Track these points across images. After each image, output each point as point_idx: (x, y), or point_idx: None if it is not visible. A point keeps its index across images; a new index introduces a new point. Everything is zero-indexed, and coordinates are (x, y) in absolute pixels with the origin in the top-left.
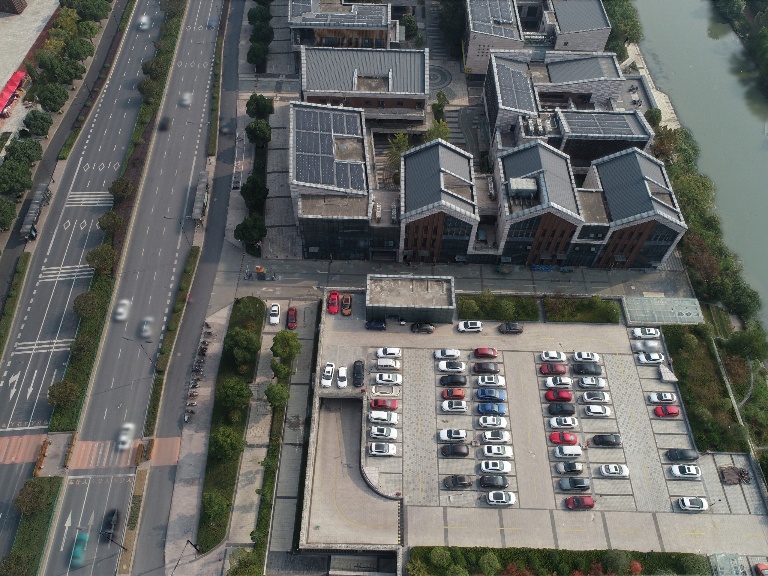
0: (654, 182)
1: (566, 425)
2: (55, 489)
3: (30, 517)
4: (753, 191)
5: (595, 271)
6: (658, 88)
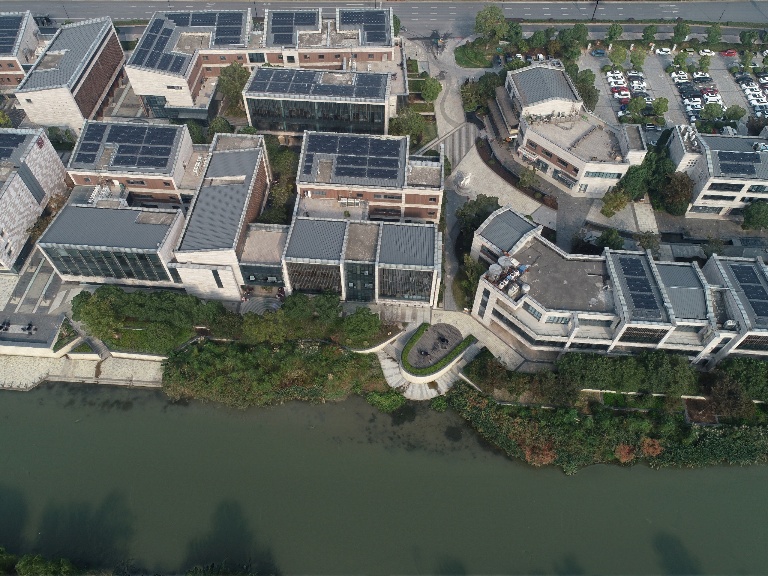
0: None
1: None
2: None
3: None
4: None
5: None
6: None
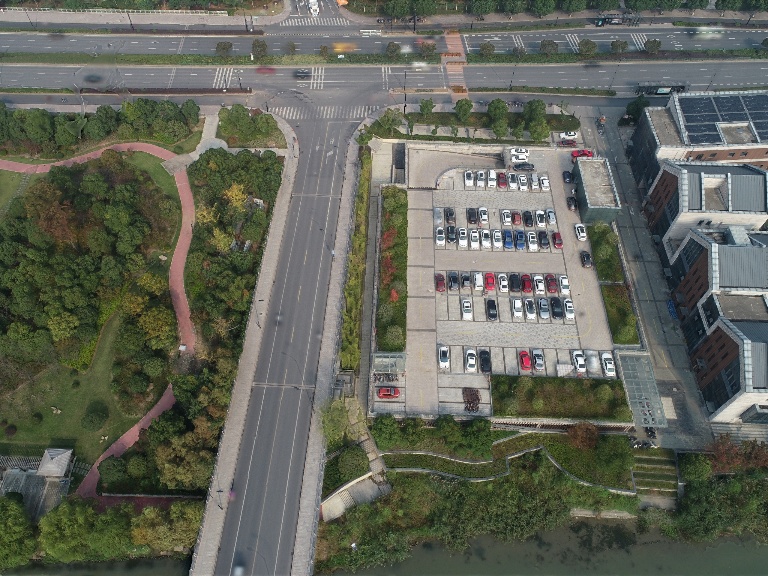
0: None
1: None
2: (434, 61)
3: (419, 56)
4: None
5: (685, 357)
6: None
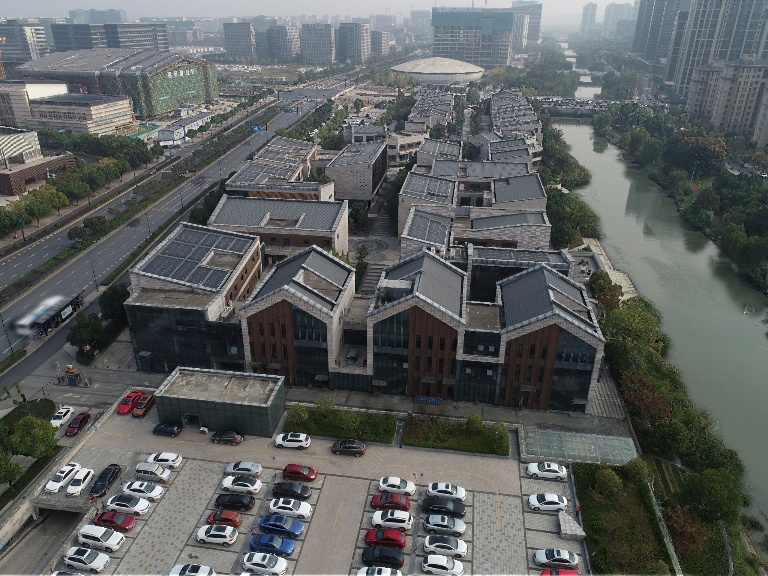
0: (562, 293)
1: None
2: None
3: None
4: (732, 357)
5: (500, 410)
6: (616, 268)
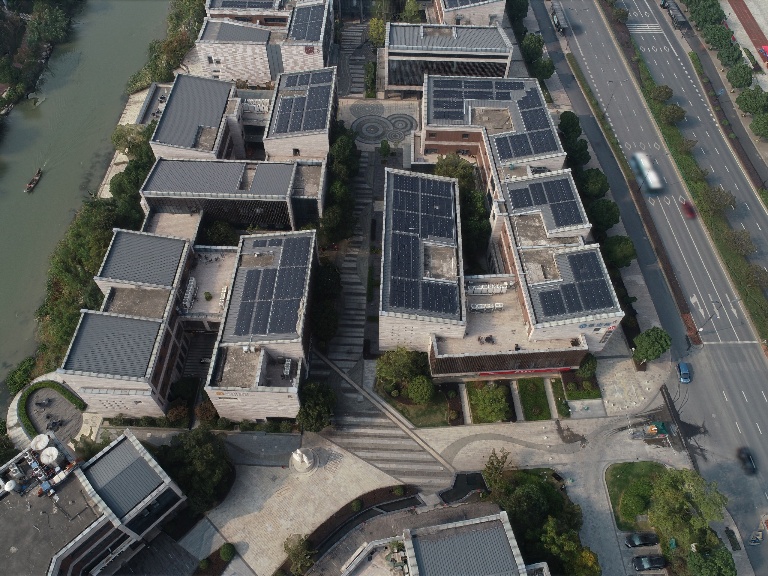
0: None
1: None
2: None
3: None
4: (113, 50)
5: None
6: None
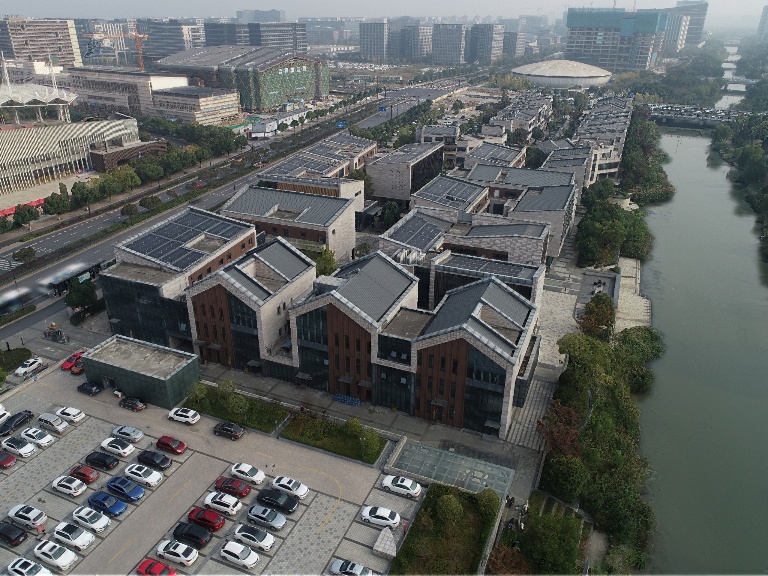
0: (494, 308)
1: (173, 554)
2: None
3: None
4: (725, 406)
5: (414, 420)
6: None
